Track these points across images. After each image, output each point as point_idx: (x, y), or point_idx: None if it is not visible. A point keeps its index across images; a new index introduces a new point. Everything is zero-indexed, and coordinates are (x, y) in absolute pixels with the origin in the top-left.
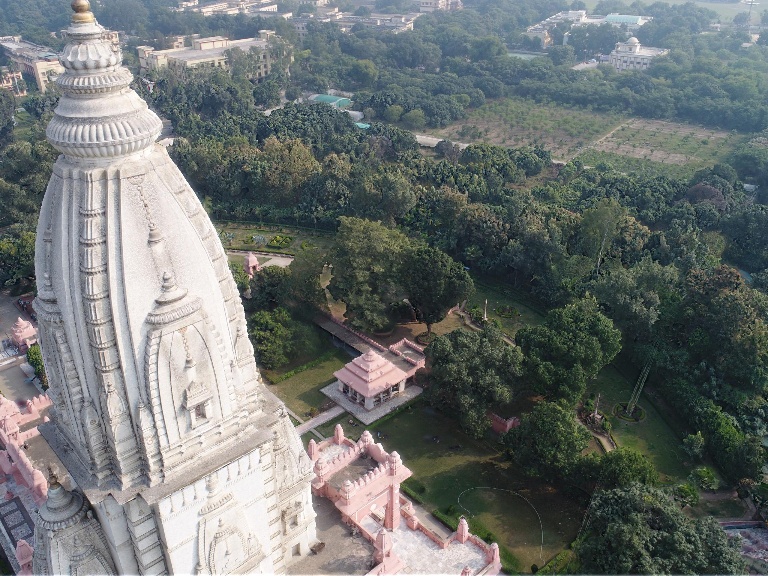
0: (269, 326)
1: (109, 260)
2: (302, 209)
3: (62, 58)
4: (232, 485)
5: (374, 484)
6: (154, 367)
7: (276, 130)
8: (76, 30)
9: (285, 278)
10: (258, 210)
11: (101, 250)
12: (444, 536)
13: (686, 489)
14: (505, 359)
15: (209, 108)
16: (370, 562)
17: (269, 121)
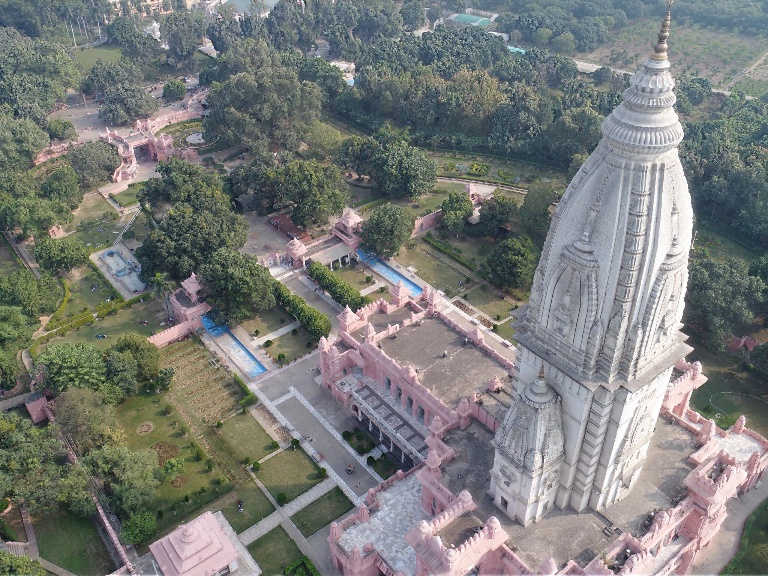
0: (522, 251)
1: (651, 227)
2: (495, 139)
3: (642, 85)
4: (657, 382)
5: (682, 386)
6: (657, 300)
7: (438, 55)
8: (658, 65)
9: (514, 207)
10: (454, 139)
11: (646, 219)
12: None
13: None
14: (750, 287)
15: (366, 31)
16: (695, 444)
17: (430, 46)
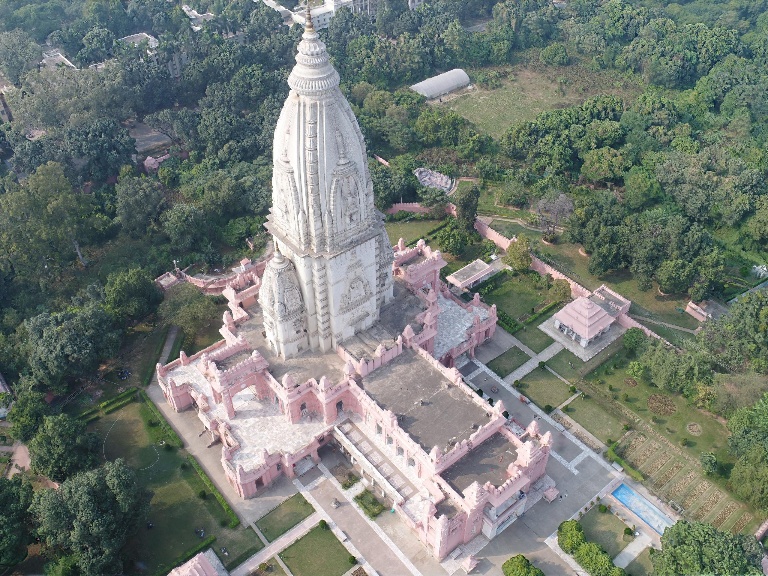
0: None
1: None
2: None
3: None
4: None
5: None
6: None
7: None
8: None
9: None
10: None
11: None
12: (182, 429)
13: (4, 394)
14: None
15: None
16: None
17: None
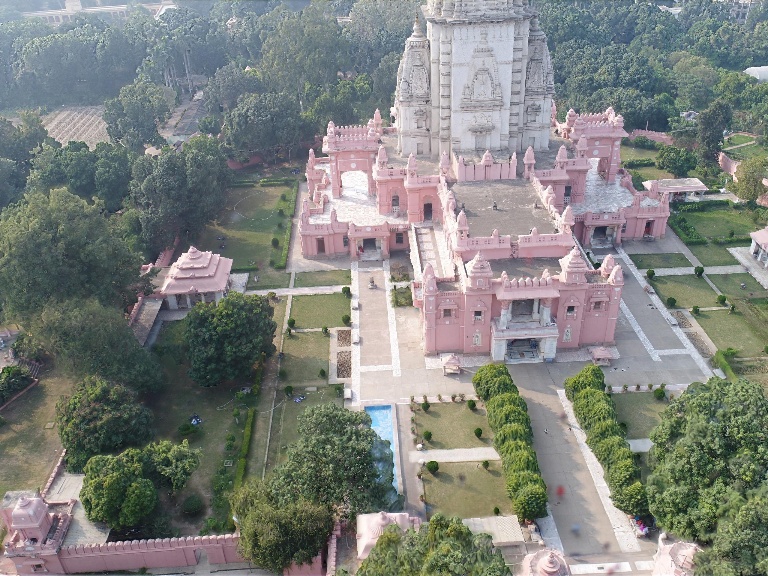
0: None
1: None
2: None
3: None
4: None
5: None
6: None
7: None
8: None
9: None
10: None
11: None
12: None
13: None
14: None
15: None
16: None
17: None
